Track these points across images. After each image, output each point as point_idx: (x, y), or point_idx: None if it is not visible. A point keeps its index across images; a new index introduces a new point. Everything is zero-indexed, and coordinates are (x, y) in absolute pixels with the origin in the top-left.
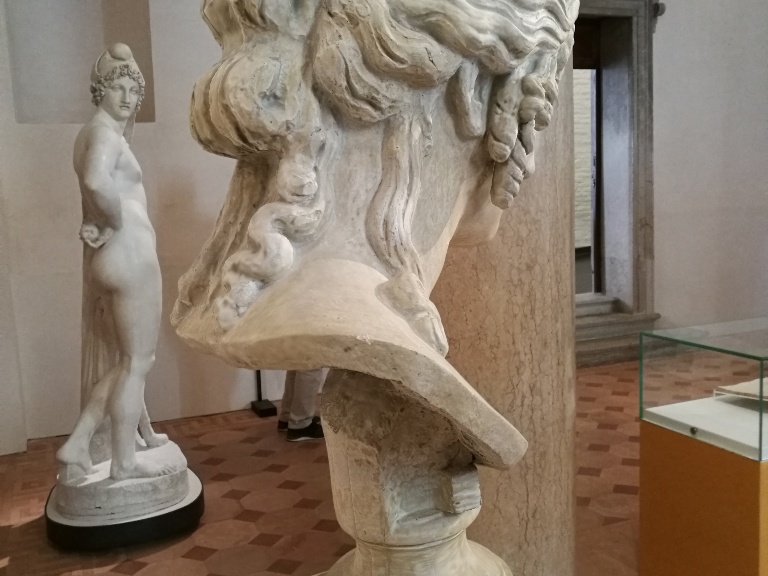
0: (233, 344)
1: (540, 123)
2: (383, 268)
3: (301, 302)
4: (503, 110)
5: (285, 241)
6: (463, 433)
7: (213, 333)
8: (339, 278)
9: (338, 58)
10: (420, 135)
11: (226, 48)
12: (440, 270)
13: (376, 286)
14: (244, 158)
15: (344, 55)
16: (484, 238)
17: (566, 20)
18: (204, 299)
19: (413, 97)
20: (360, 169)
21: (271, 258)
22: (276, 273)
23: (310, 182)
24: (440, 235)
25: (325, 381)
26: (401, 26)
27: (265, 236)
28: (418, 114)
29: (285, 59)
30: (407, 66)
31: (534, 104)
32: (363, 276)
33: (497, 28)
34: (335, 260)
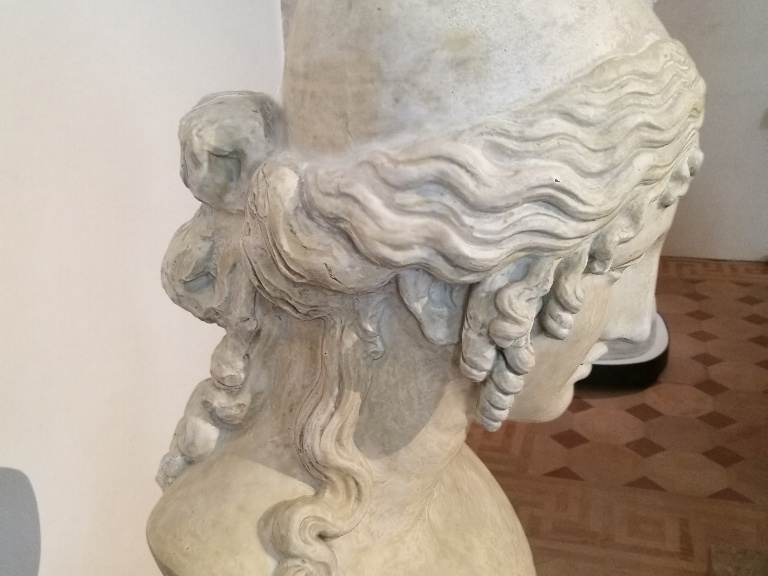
0: None
1: (552, 334)
2: (308, 475)
3: (183, 508)
4: (470, 326)
5: (206, 428)
6: None
7: None
8: (233, 489)
9: (244, 257)
10: (357, 341)
11: None
12: (439, 460)
13: (274, 504)
14: None
15: (248, 255)
16: (532, 421)
17: (582, 211)
18: None
19: (344, 300)
20: (299, 361)
21: (186, 445)
22: (195, 457)
23: (231, 375)
24: (415, 436)
25: None
26: (311, 227)
27: (188, 419)
28: (352, 319)
29: (220, 236)
30: (307, 281)
31: (501, 332)
32: (264, 489)
33: (430, 240)
34: (247, 461)
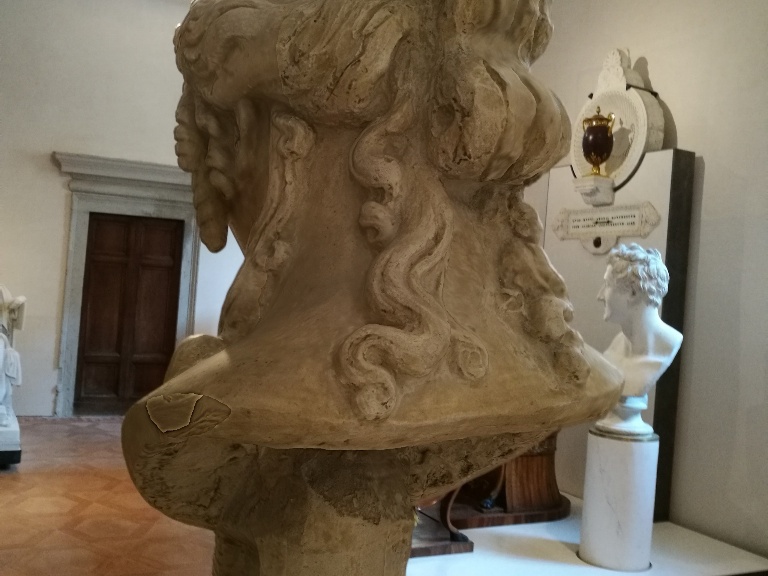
0: (606, 394)
1: None
2: None
3: None
4: None
5: None
6: (431, 476)
7: (555, 393)
8: None
9: None
10: None
11: (488, 46)
12: None
13: None
14: (443, 177)
15: None
16: None
17: None
18: (473, 360)
19: None
20: None
21: None
22: None
23: None
24: None
25: (308, 475)
26: None
27: None
28: None
29: None
30: None
31: None
32: None
33: None
34: None
